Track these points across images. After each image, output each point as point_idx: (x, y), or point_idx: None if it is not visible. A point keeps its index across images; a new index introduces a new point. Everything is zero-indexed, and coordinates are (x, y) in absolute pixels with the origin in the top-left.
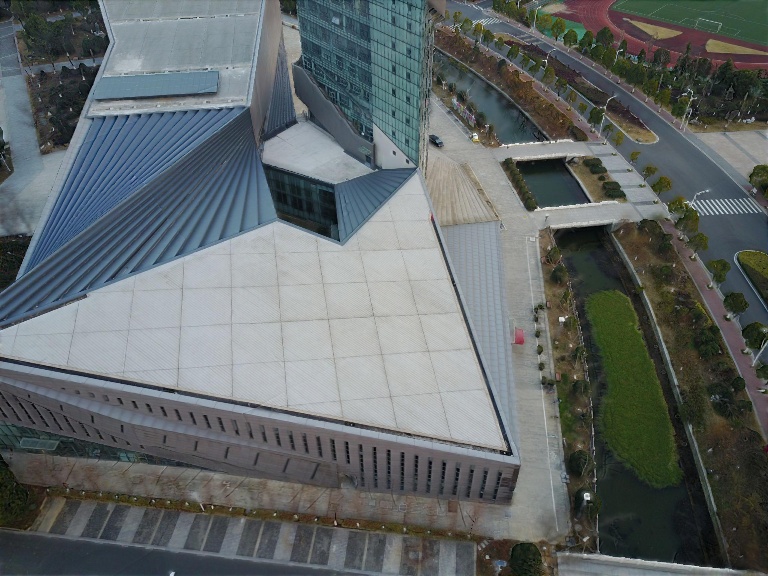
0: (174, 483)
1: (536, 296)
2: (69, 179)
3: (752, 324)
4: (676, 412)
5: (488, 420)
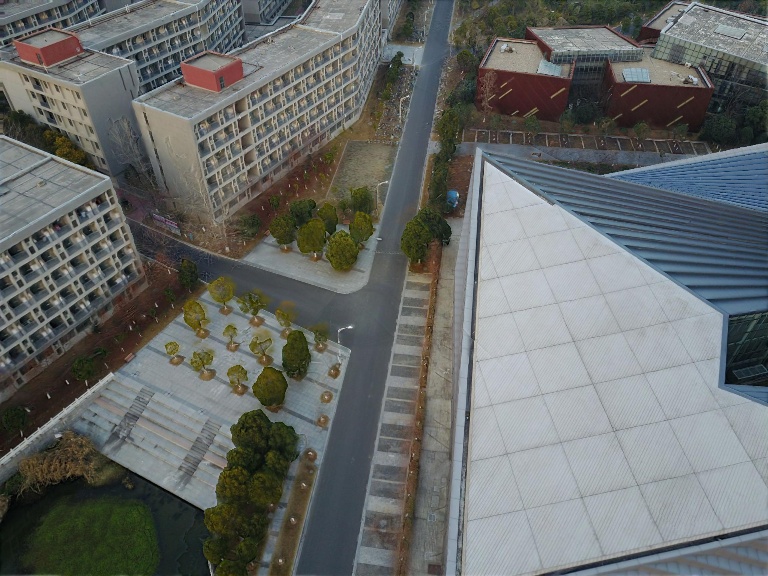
0: (446, 337)
1: None
2: (707, 163)
3: None
4: None
5: (499, 570)
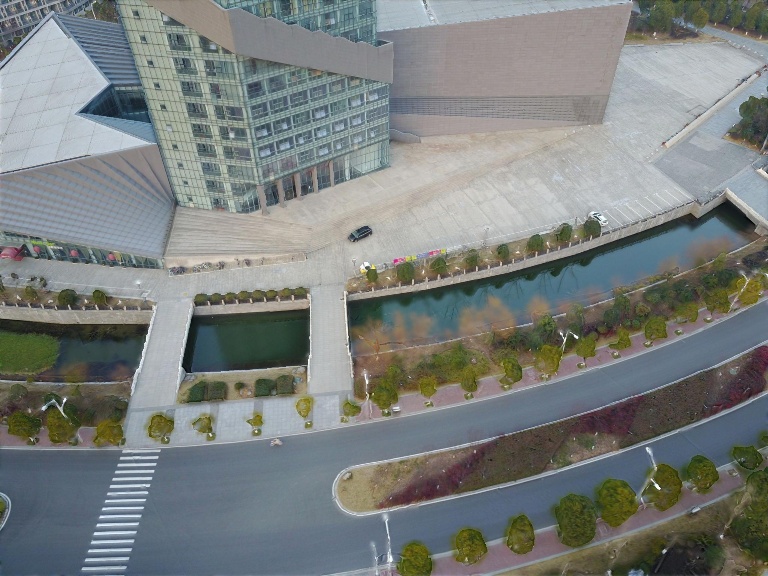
0: None
1: (63, 285)
2: None
3: None
4: None
5: None
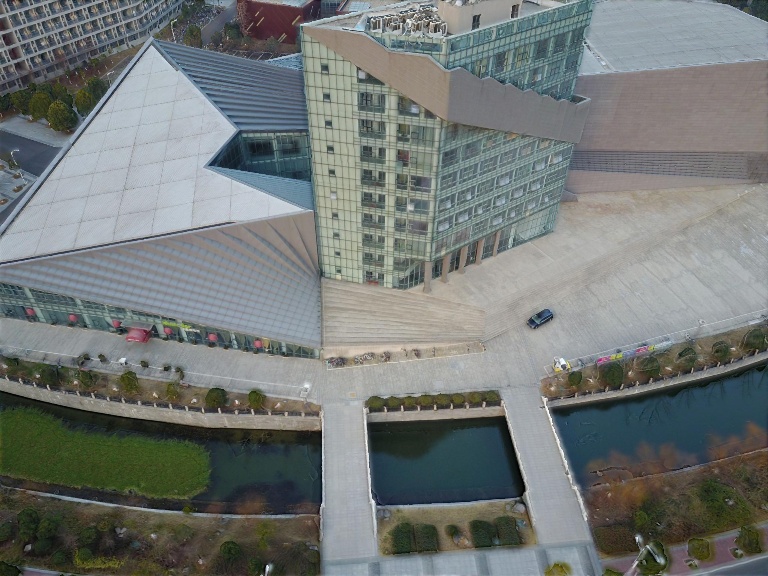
0: None
1: (203, 378)
2: None
3: (4, 565)
4: (3, 483)
5: (8, 256)
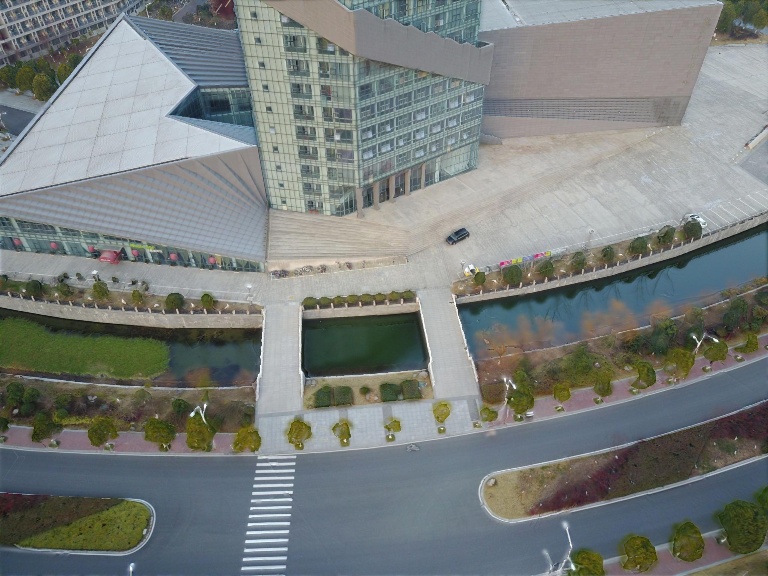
0: None
1: (165, 289)
2: None
3: None
4: None
5: None
